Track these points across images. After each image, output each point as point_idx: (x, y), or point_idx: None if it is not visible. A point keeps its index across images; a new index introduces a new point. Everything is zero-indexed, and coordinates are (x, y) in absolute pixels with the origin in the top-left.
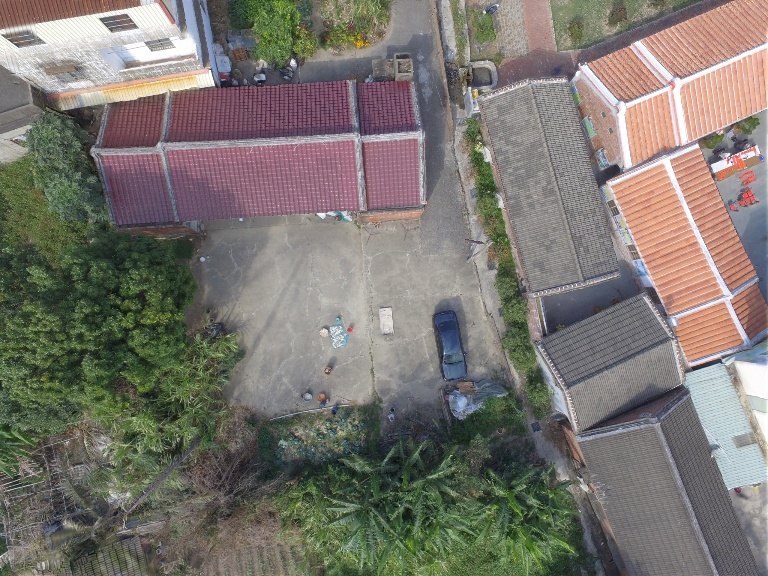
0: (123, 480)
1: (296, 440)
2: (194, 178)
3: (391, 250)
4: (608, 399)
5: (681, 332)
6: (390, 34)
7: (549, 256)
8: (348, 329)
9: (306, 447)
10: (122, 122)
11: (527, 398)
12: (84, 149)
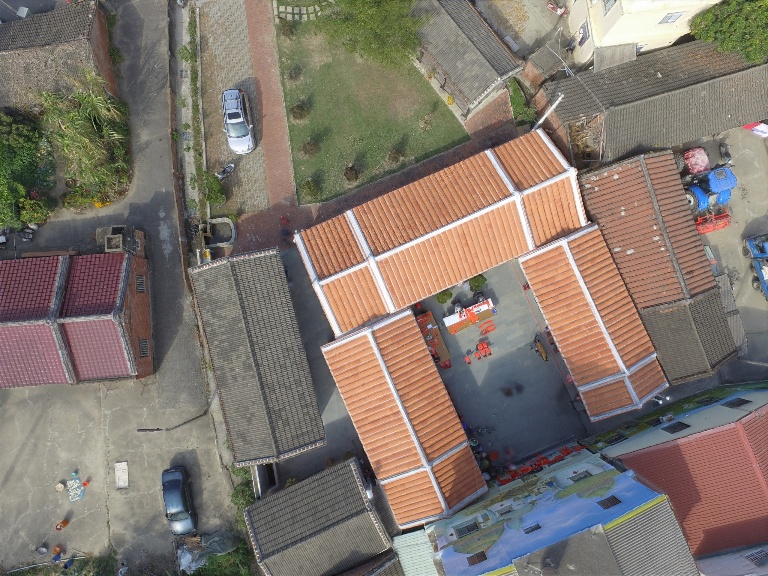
0: None
1: None
2: None
3: (129, 405)
4: (309, 567)
5: (391, 496)
6: (133, 191)
7: (249, 428)
8: (84, 483)
9: None
10: None
11: None
12: None
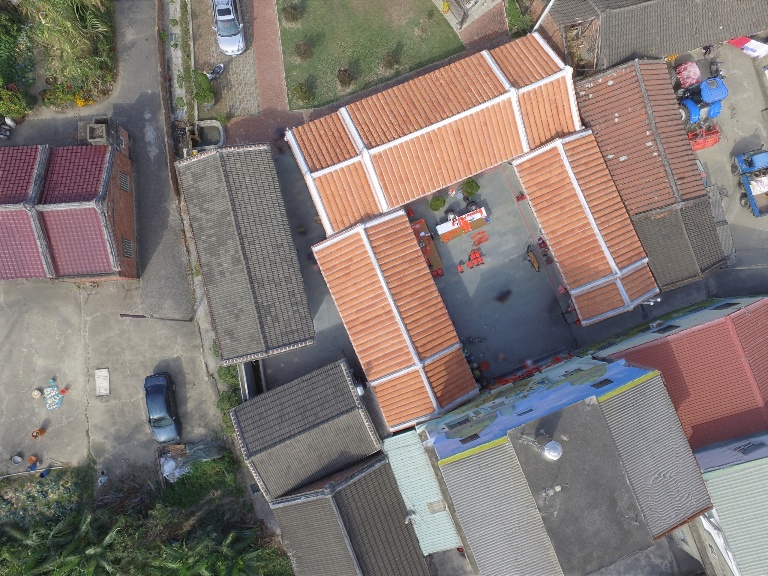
0: None
1: (4, 503)
2: None
3: (110, 310)
4: (298, 467)
5: (382, 398)
6: (117, 91)
7: (237, 324)
8: (62, 391)
9: (16, 510)
10: None
11: None
12: None
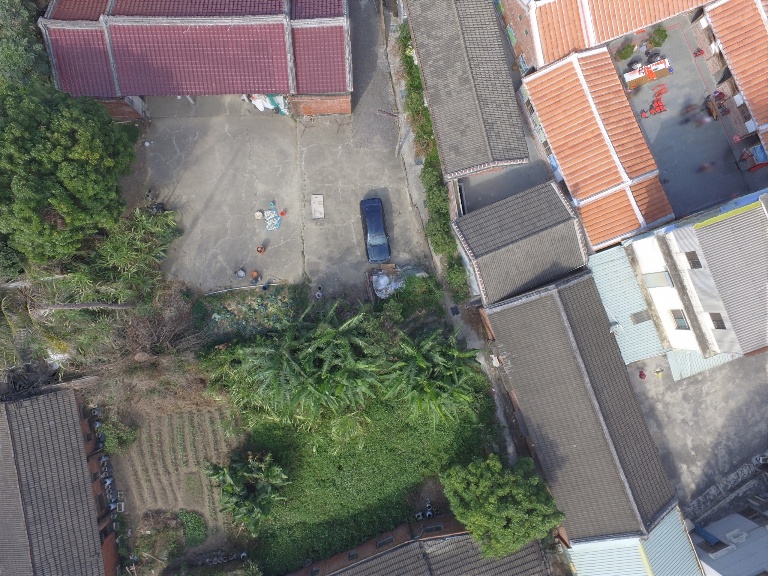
0: (60, 335)
1: (228, 314)
2: (135, 53)
3: (324, 142)
4: (515, 274)
5: (586, 218)
6: None
7: (463, 140)
8: (281, 213)
9: (238, 321)
10: (70, 1)
11: (447, 283)
12: (32, 21)
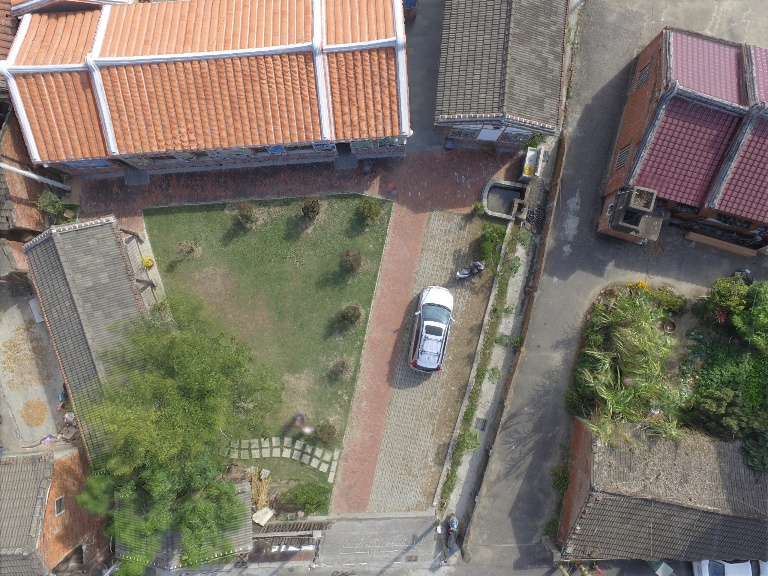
0: None
1: None
2: None
3: None
4: None
5: None
6: (594, 291)
7: None
8: None
9: None
10: None
11: None
12: None
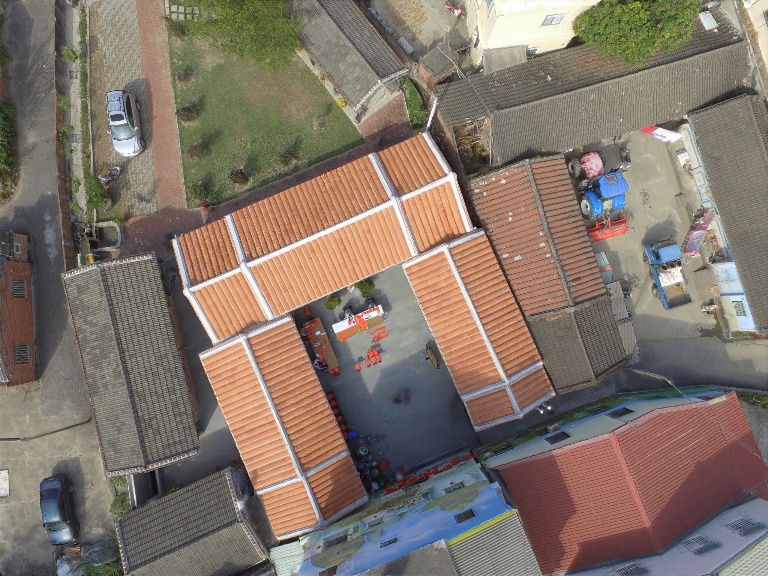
0: None
1: None
2: None
3: (11, 412)
4: None
5: (268, 506)
6: (18, 194)
7: (119, 437)
8: None
9: None
10: None
11: None
12: None
